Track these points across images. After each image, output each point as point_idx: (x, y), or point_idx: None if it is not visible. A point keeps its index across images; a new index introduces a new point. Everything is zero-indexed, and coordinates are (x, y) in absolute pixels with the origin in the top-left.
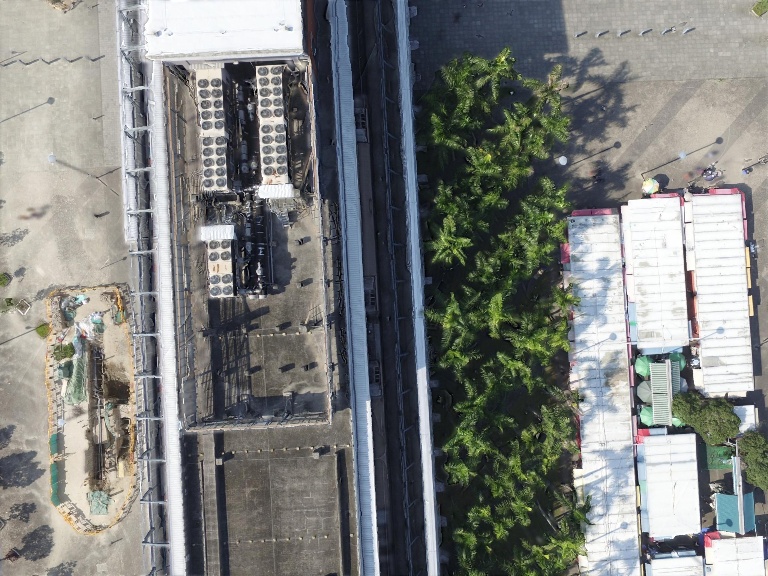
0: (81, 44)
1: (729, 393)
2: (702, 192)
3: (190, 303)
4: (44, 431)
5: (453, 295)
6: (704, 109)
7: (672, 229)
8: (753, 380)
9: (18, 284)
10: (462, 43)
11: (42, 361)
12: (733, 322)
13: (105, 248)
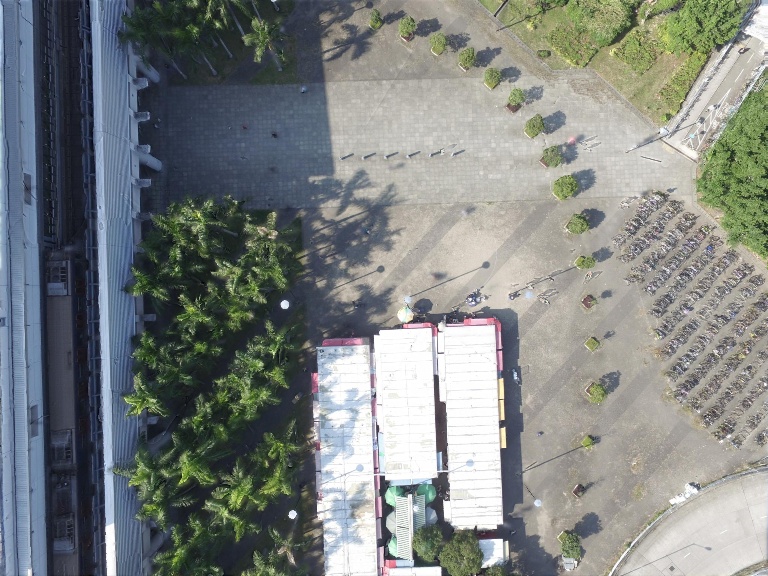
0: None
1: (478, 526)
2: (464, 318)
3: None
4: None
5: (137, 455)
6: (471, 233)
7: (423, 360)
8: (502, 514)
9: None
10: (226, 165)
11: None
12: (483, 455)
13: None
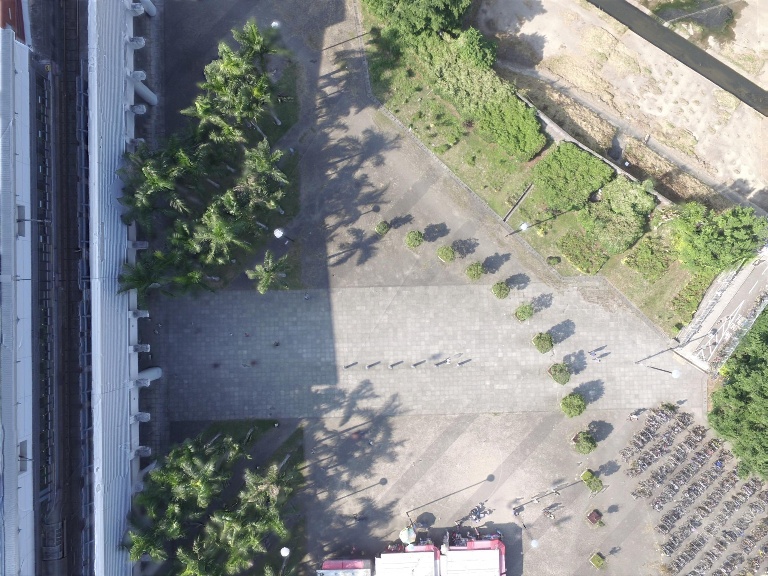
0: None
1: None
2: (468, 534)
3: None
4: None
5: None
6: (476, 445)
7: None
8: None
9: None
10: (227, 373)
11: None
12: None
13: None
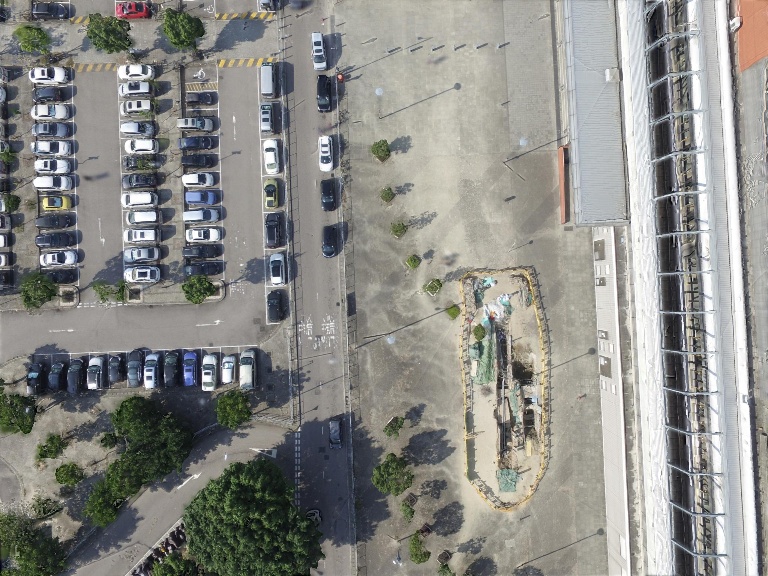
0: (486, 31)
1: None
2: None
3: (747, 282)
4: (454, 410)
5: None
6: None
7: None
8: None
9: (427, 266)
10: None
11: (451, 341)
12: None
13: (512, 232)
